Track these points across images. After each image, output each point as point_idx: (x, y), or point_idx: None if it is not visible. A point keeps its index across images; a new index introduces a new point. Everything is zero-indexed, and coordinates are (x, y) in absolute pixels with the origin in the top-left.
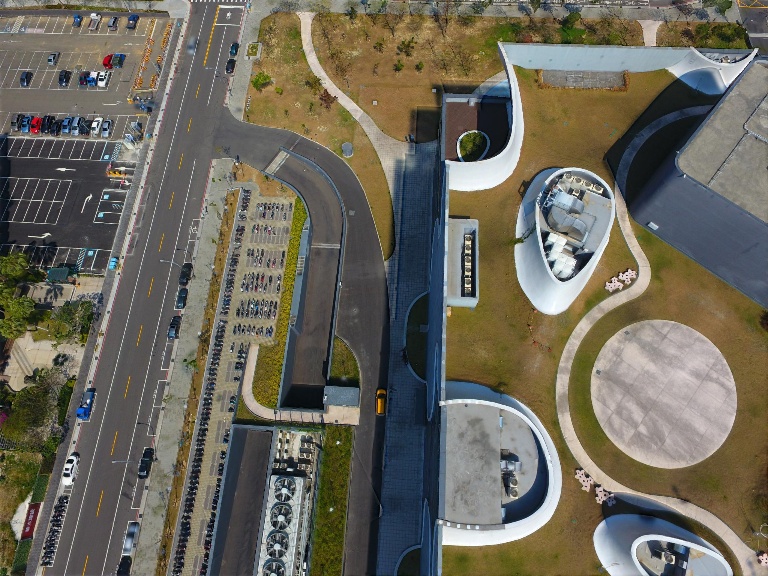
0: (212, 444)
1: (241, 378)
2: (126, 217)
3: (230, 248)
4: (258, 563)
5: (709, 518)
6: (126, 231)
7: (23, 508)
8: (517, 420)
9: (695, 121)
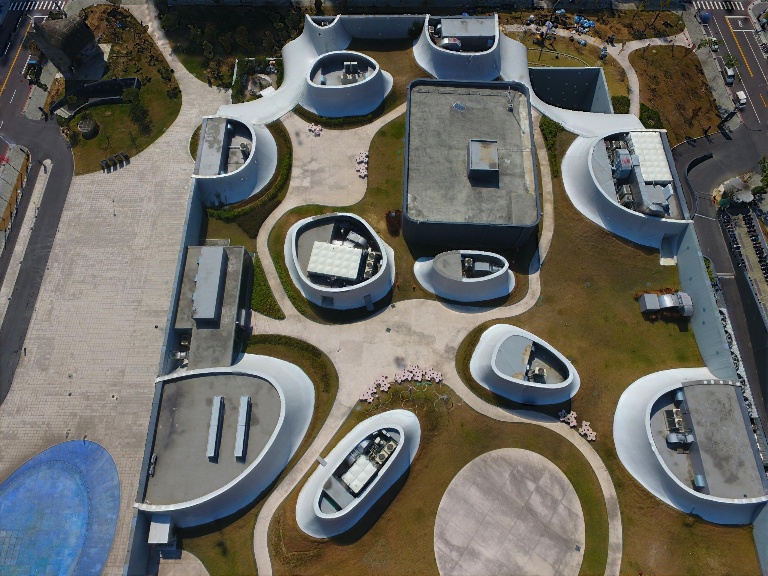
0: None
1: None
2: None
3: None
4: None
5: (479, 407)
6: None
7: None
8: None
9: None
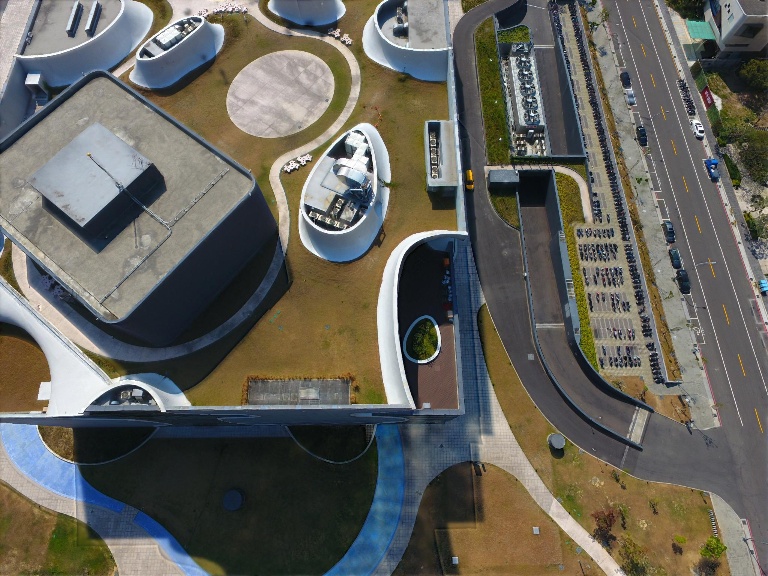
0: (596, 152)
1: None
2: None
3: (650, 308)
4: None
5: (271, 26)
6: None
7: (718, 107)
8: None
9: (179, 338)
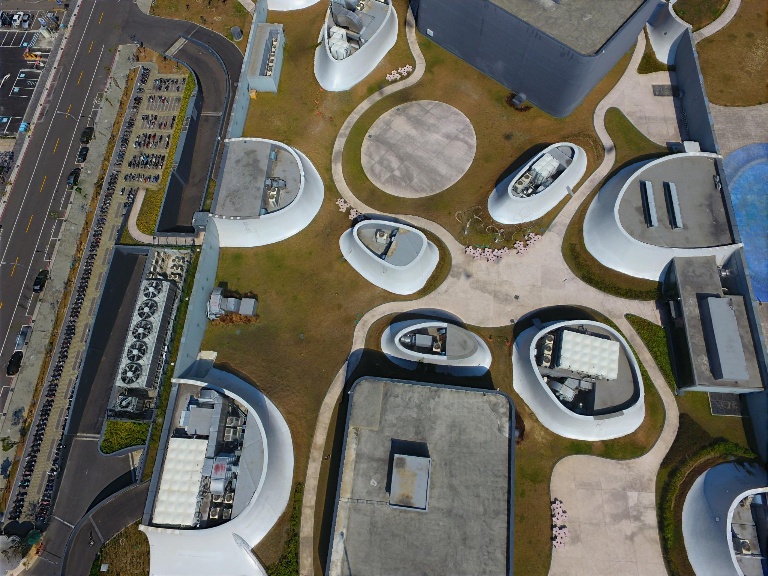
0: (99, 266)
1: (126, 212)
2: (39, 91)
3: (127, 113)
4: (126, 346)
5: (434, 226)
6: (38, 102)
7: None
8: (290, 158)
9: None
